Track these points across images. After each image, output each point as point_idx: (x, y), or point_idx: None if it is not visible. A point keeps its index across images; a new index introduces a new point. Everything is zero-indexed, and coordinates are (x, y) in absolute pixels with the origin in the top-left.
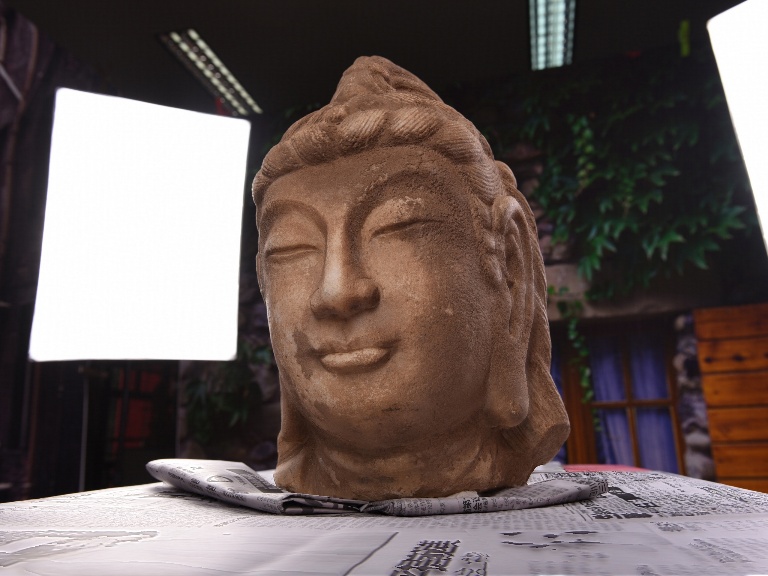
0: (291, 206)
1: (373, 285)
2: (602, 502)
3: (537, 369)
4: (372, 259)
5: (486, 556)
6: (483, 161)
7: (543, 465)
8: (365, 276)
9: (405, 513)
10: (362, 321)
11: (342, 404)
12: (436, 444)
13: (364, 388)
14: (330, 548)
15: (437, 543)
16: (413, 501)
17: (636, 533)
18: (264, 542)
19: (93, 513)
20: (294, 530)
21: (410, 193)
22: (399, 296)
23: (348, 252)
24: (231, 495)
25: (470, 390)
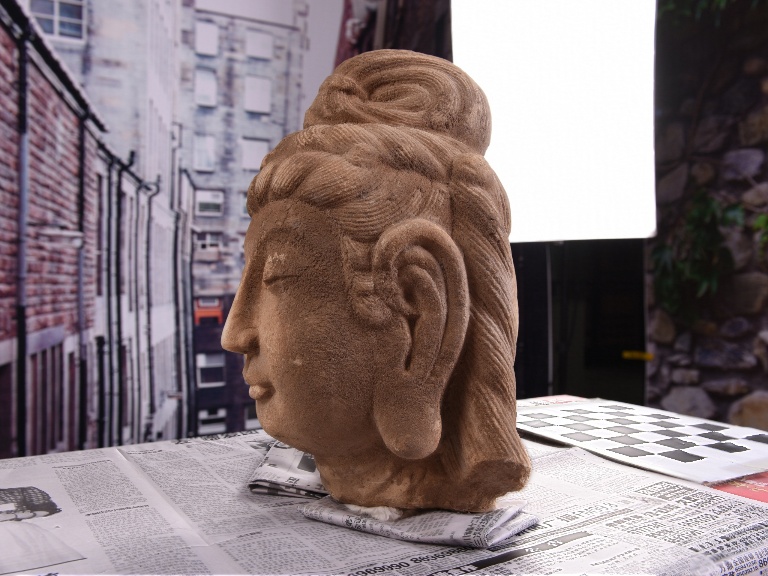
0: None
1: (252, 335)
2: (453, 558)
3: (474, 399)
4: None
5: None
6: (370, 193)
7: None
8: (250, 326)
9: None
10: (251, 363)
11: None
12: (344, 464)
13: (261, 416)
14: None
15: None
16: (310, 509)
17: None
18: (30, 543)
19: (118, 476)
20: (82, 534)
21: (280, 248)
22: (264, 347)
23: (241, 305)
24: None
25: (347, 426)
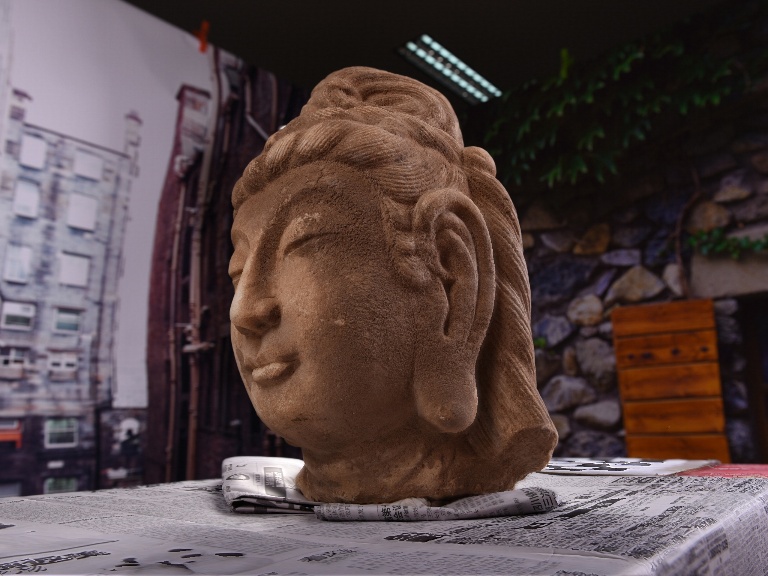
0: (238, 235)
1: (273, 303)
2: (530, 518)
3: (505, 368)
4: (281, 278)
5: (42, 570)
6: (406, 159)
7: (686, 464)
8: (269, 295)
9: (327, 518)
10: (267, 338)
11: (265, 415)
12: (368, 451)
13: (275, 400)
14: (6, 551)
15: (86, 554)
16: (332, 506)
17: (262, 560)
18: (10, 541)
19: None
20: None
21: (311, 209)
22: (293, 312)
23: (255, 275)
24: (222, 492)
25: (385, 397)
